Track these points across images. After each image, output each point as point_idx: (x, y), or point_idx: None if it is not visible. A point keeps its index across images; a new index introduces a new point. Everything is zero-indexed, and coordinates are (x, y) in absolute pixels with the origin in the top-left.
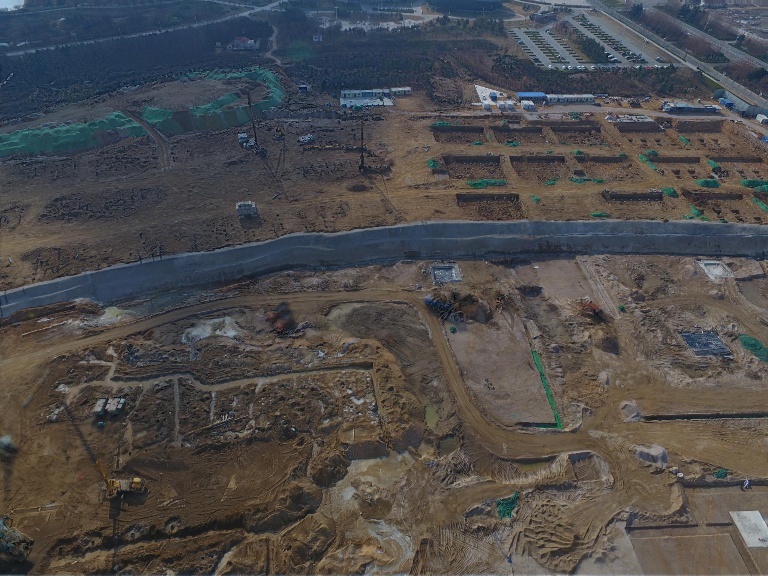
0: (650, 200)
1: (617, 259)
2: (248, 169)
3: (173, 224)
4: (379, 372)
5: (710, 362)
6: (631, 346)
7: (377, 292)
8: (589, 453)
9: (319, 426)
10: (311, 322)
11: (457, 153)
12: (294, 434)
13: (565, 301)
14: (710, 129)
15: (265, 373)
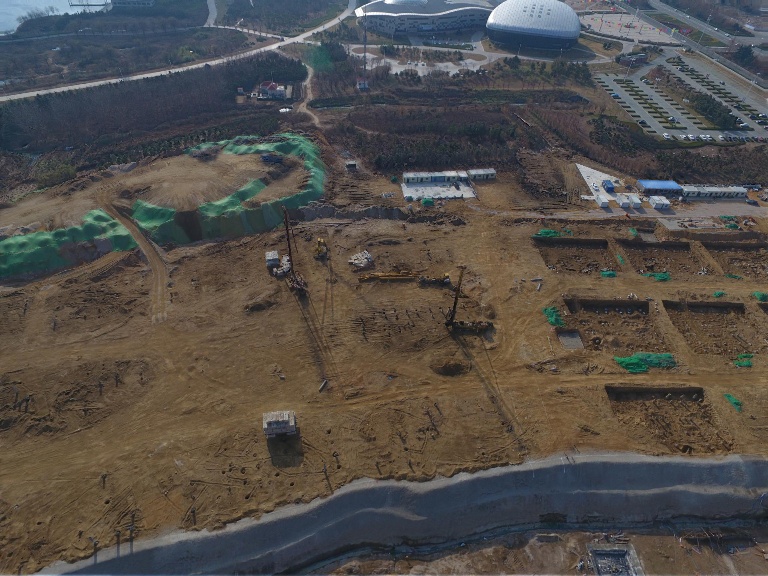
0: None
1: None
2: (280, 320)
3: (159, 451)
4: None
5: None
6: None
7: None
8: None
9: None
10: None
11: (584, 294)
12: None
13: None
14: None
15: None
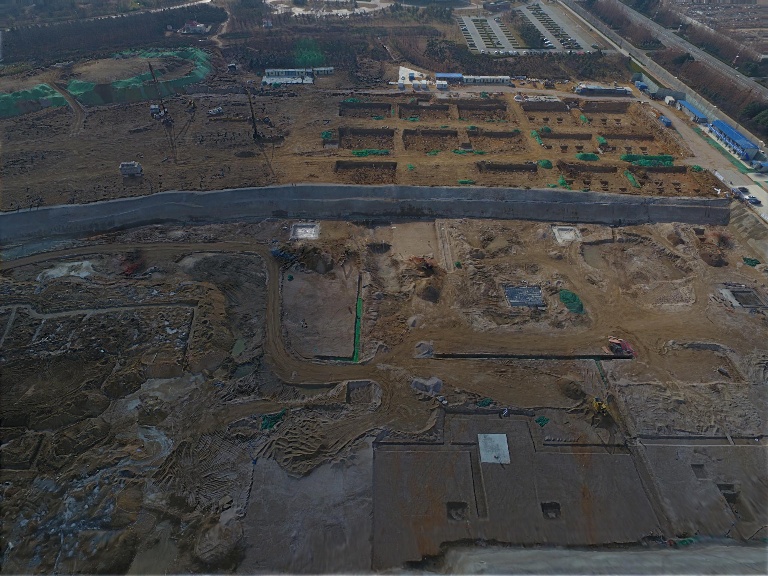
0: (525, 171)
1: (473, 222)
2: (150, 136)
3: (61, 181)
4: (201, 308)
5: (521, 312)
6: (451, 296)
7: (232, 244)
8: (369, 382)
9: (126, 349)
10: (160, 267)
11: (354, 126)
12: (102, 355)
13: (408, 257)
14: (616, 110)
15: (97, 306)
